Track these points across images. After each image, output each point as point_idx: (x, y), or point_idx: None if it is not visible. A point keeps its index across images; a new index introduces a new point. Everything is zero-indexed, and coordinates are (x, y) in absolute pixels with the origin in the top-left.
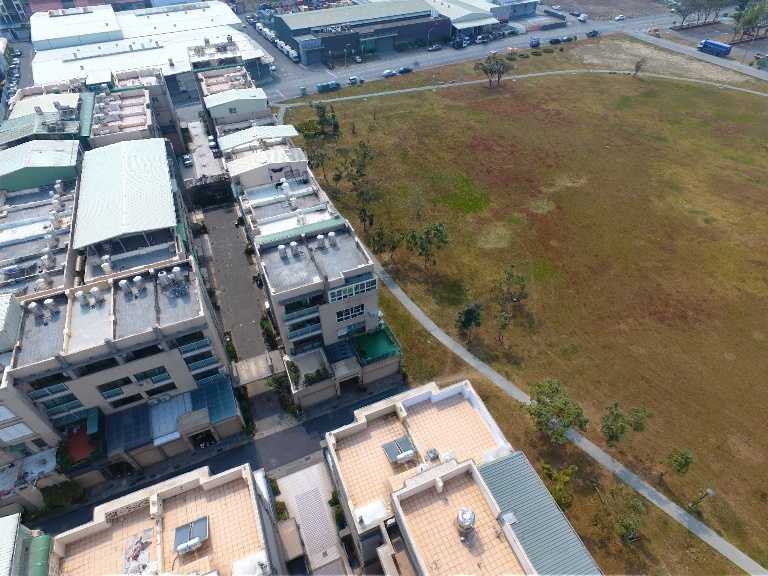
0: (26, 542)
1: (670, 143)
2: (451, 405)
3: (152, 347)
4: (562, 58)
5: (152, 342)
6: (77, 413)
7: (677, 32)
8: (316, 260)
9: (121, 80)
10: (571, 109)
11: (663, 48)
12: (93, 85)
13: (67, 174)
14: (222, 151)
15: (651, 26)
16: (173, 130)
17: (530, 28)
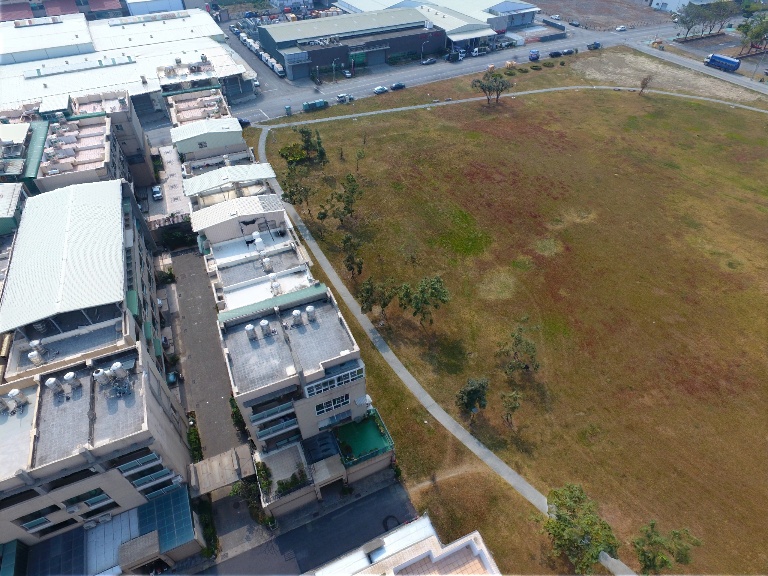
0: None
1: (683, 171)
2: (457, 567)
3: None
4: (563, 73)
5: (81, 467)
6: None
7: (681, 44)
8: (291, 342)
9: (82, 104)
10: (575, 131)
11: (668, 62)
12: (47, 113)
13: (4, 226)
14: None
15: (655, 38)
16: (141, 160)
17: (528, 39)
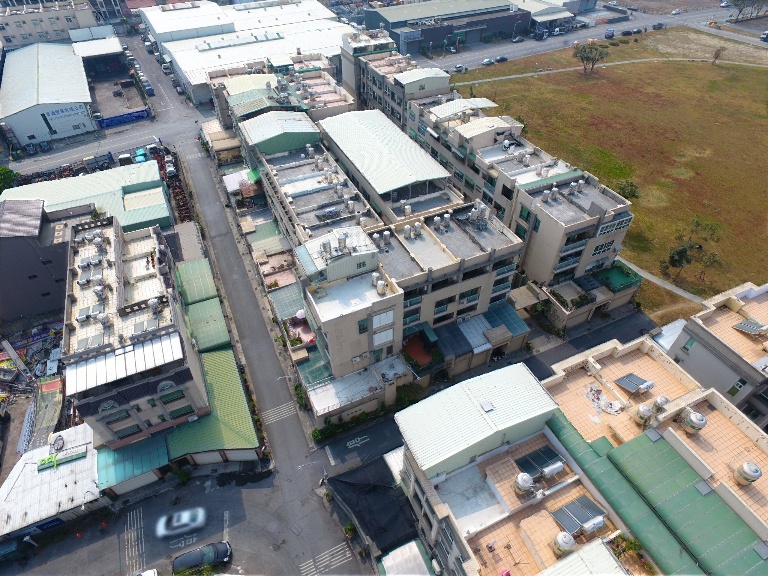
0: None
1: None
2: (766, 300)
3: (473, 270)
4: (639, 48)
5: (486, 263)
6: (414, 326)
7: (734, 24)
8: None
9: None
10: (668, 92)
11: (728, 39)
12: (279, 67)
13: (312, 139)
14: (427, 121)
15: (712, 19)
16: None
17: (598, 21)
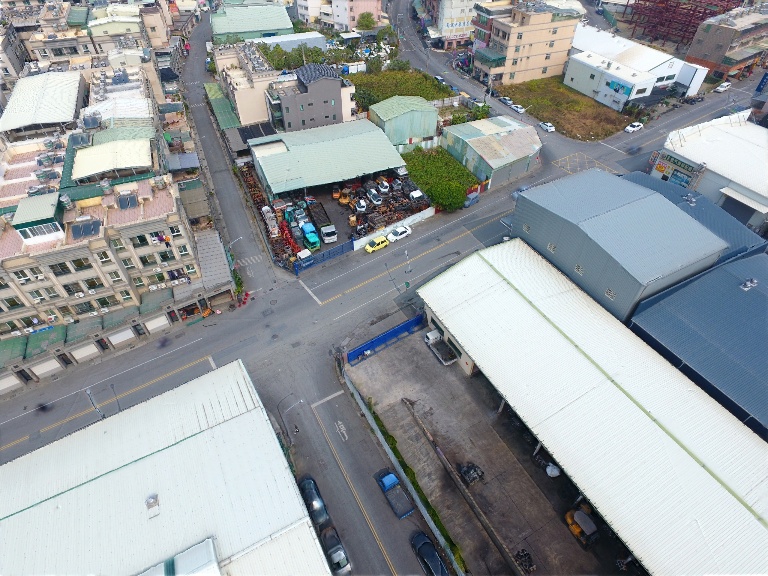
0: None
1: None
2: None
3: None
4: None
5: None
6: None
7: None
8: None
9: None
10: None
11: None
12: None
13: None
14: None
15: None
16: None
17: None
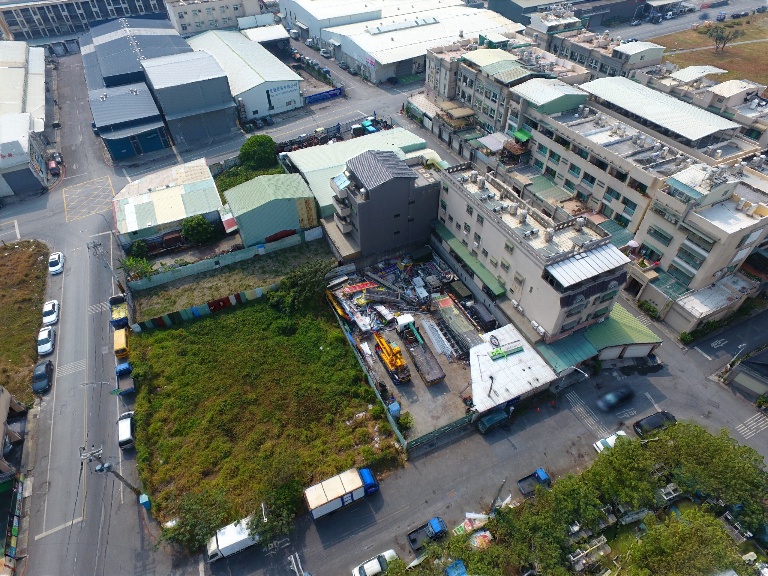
0: None
1: None
2: None
3: None
4: (754, 29)
5: None
6: None
7: None
8: None
9: None
10: None
11: None
12: (498, 43)
13: (580, 102)
14: (661, 87)
15: None
16: None
17: (702, 6)
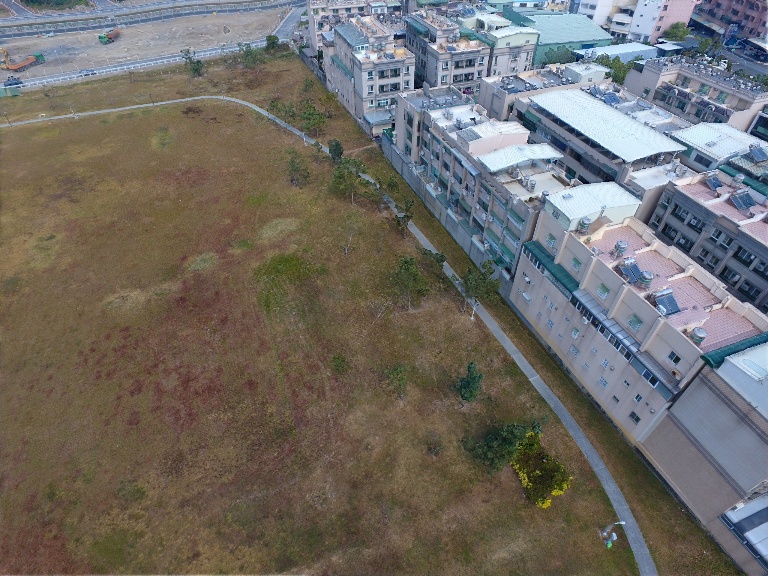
0: (494, 42)
1: None
2: None
3: None
4: None
5: None
6: None
7: None
8: None
9: None
10: None
11: None
12: None
13: None
14: None
15: None
16: None
17: None
